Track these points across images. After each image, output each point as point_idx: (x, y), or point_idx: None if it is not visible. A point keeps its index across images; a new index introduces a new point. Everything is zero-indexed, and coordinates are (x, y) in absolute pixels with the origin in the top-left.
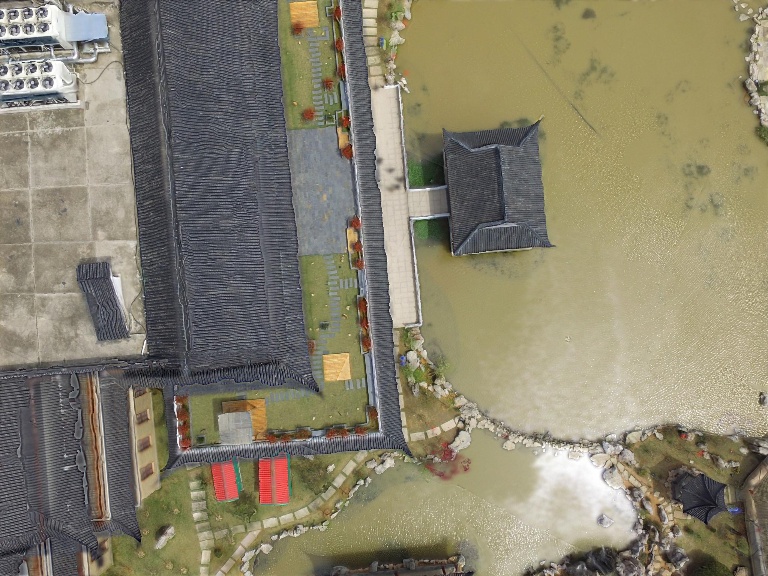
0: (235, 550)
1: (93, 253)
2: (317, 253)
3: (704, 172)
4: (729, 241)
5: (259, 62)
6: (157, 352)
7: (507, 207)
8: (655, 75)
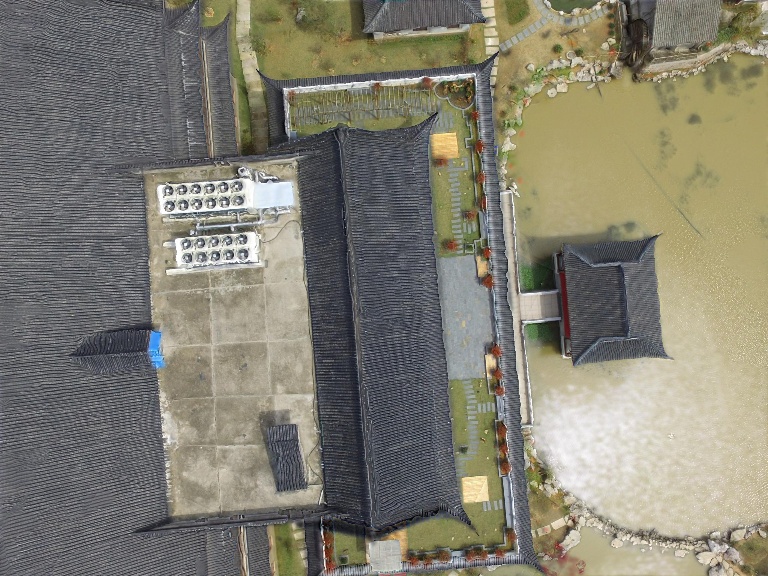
0: None
1: (272, 406)
2: (456, 378)
3: None
4: None
5: None
6: (336, 504)
7: (629, 323)
8: (759, 180)
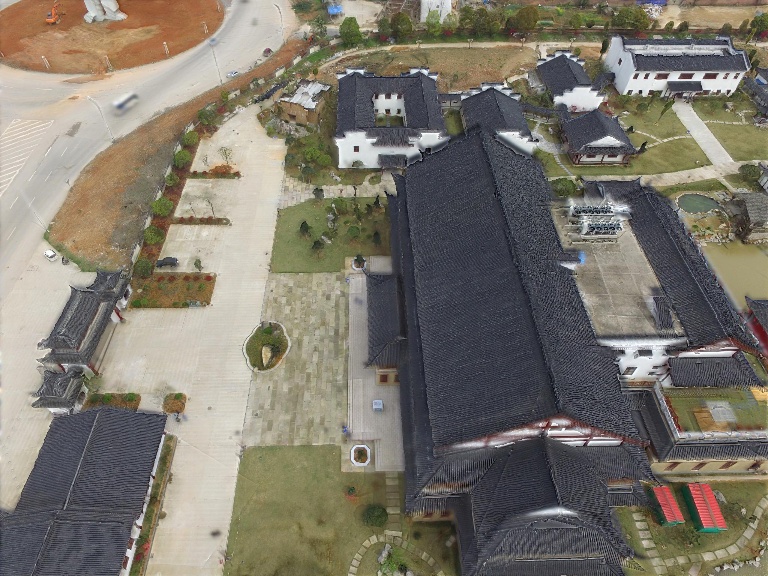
0: None
1: (643, 300)
2: None
3: None
4: None
5: None
6: None
7: None
8: None
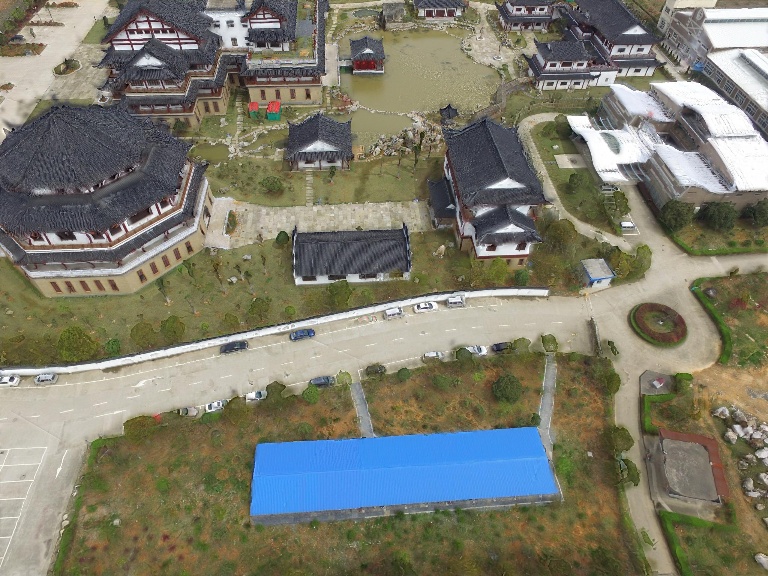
0: (252, 132)
1: None
2: None
3: (449, 63)
4: None
5: (292, 0)
6: None
7: None
8: None
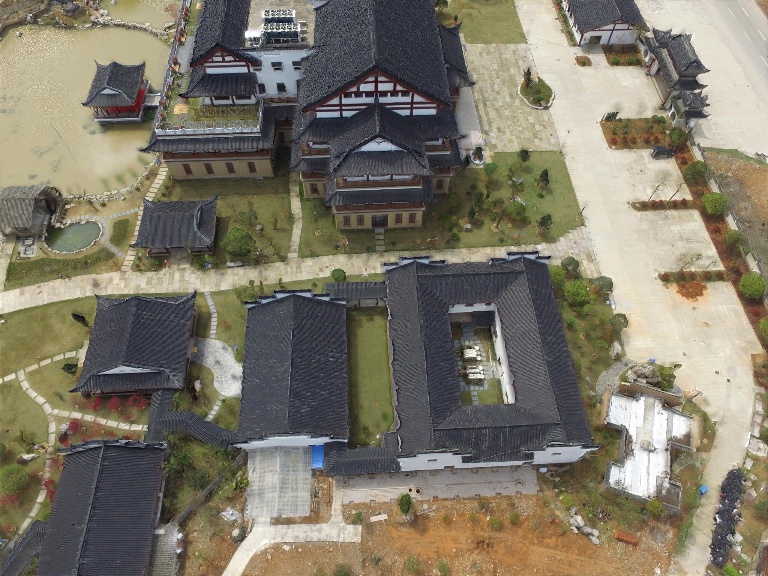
0: None
1: None
2: None
3: (3, 111)
4: (5, 86)
5: None
6: None
7: None
8: (8, 150)
